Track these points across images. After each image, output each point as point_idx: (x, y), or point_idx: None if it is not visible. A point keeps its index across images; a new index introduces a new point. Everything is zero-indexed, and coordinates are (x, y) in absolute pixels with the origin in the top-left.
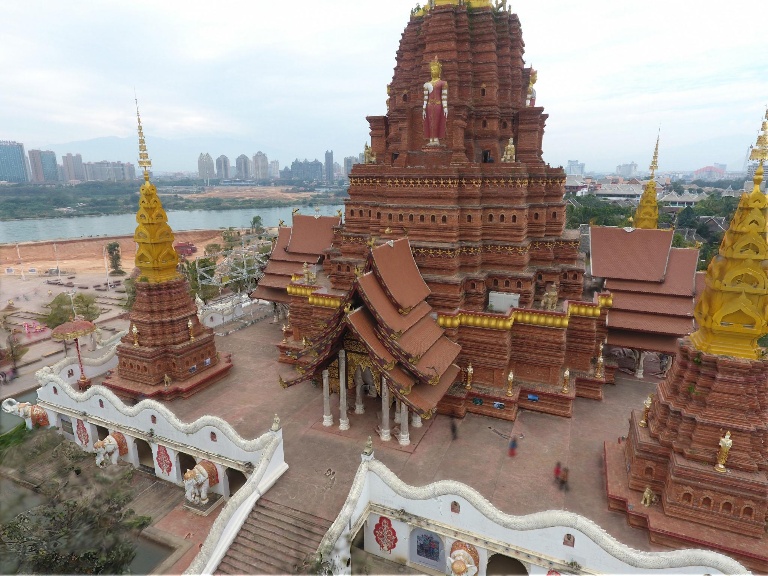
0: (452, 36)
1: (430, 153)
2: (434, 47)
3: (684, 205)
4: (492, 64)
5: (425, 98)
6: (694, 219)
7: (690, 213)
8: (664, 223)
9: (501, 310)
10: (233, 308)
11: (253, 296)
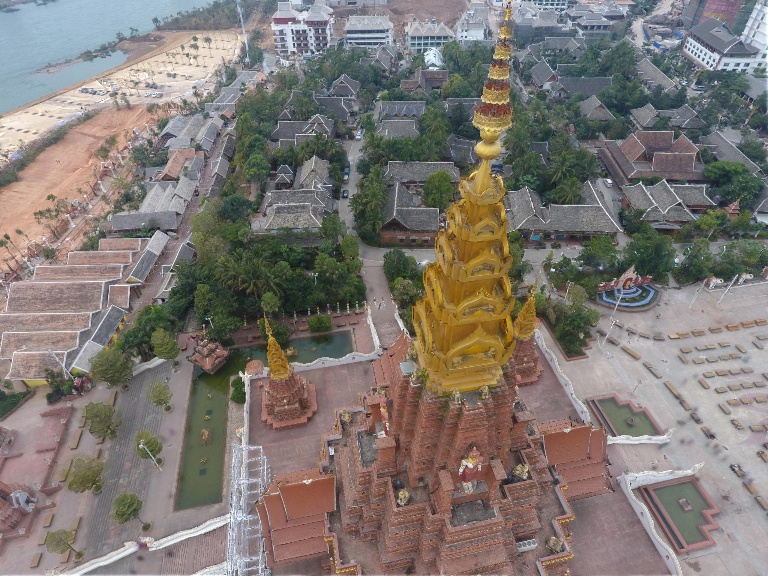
0: (485, 428)
1: (469, 495)
2: (467, 434)
3: (428, 40)
4: (507, 418)
5: (463, 468)
6: (469, 123)
7: (462, 109)
8: (450, 136)
9: (524, 551)
10: (243, 574)
11: (270, 566)
